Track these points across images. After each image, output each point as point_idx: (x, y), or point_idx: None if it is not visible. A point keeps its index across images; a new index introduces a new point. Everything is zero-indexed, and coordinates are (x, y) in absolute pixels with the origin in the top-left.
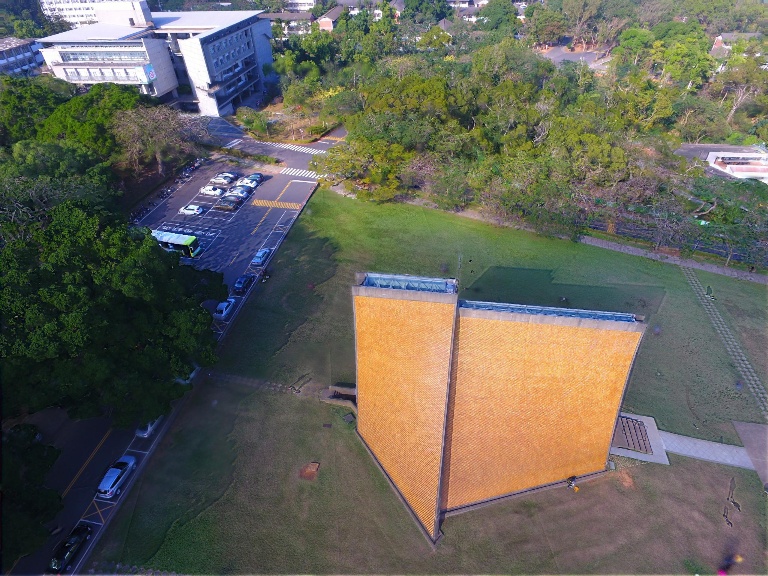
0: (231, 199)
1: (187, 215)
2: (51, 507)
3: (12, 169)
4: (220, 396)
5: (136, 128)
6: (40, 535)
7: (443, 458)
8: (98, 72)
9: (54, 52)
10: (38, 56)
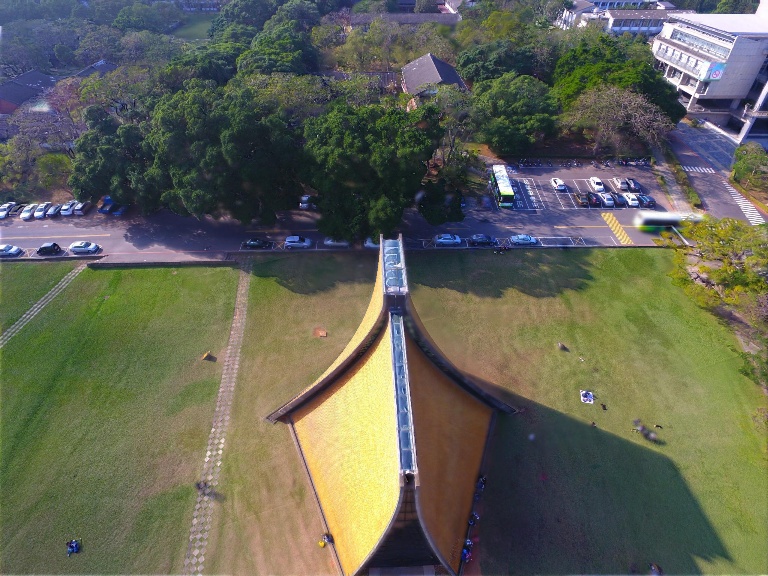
0: (591, 197)
1: (551, 185)
2: (266, 220)
3: (496, 88)
4: (367, 266)
5: (591, 100)
6: (246, 219)
7: (312, 391)
8: (679, 56)
9: (671, 28)
10: (658, 28)
